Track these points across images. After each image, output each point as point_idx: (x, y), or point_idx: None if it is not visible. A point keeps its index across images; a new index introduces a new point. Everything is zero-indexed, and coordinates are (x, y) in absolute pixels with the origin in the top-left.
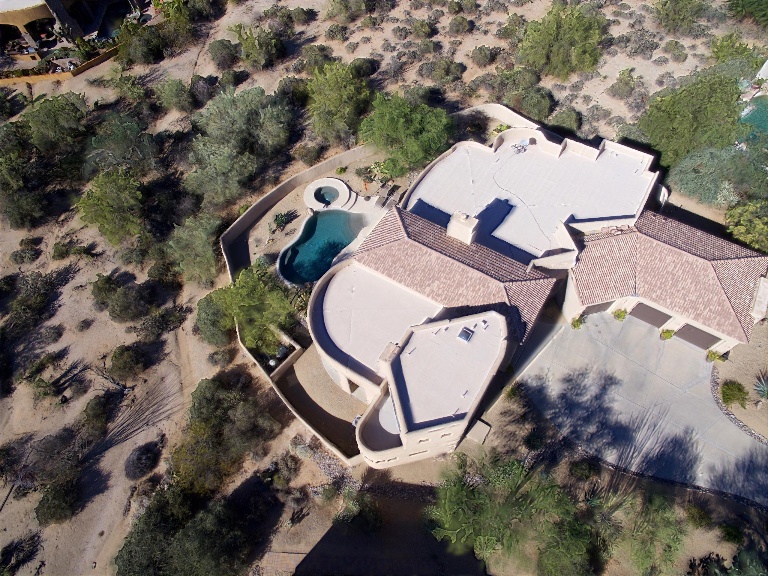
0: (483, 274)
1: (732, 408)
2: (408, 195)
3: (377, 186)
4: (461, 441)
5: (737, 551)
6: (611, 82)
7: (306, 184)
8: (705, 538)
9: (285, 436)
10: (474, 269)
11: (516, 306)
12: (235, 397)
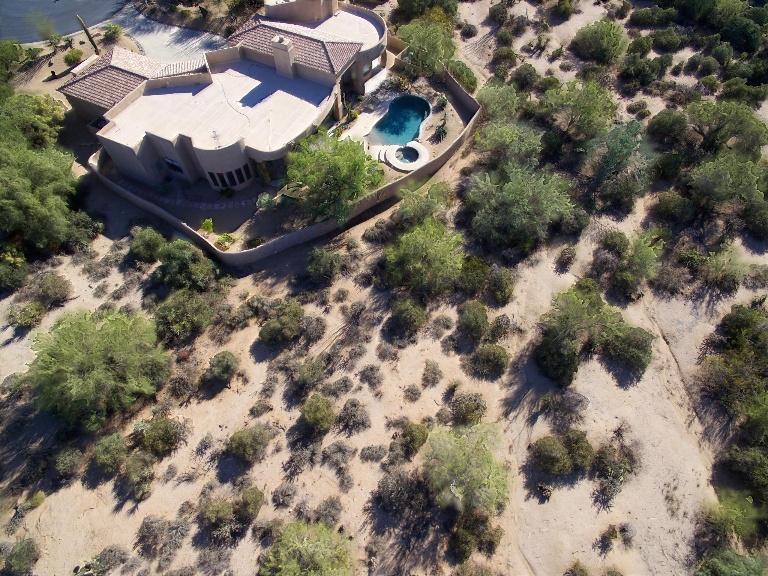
0: None
1: None
2: None
3: None
4: None
5: None
6: (52, 318)
7: None
8: None
9: None
10: None
11: None
12: None
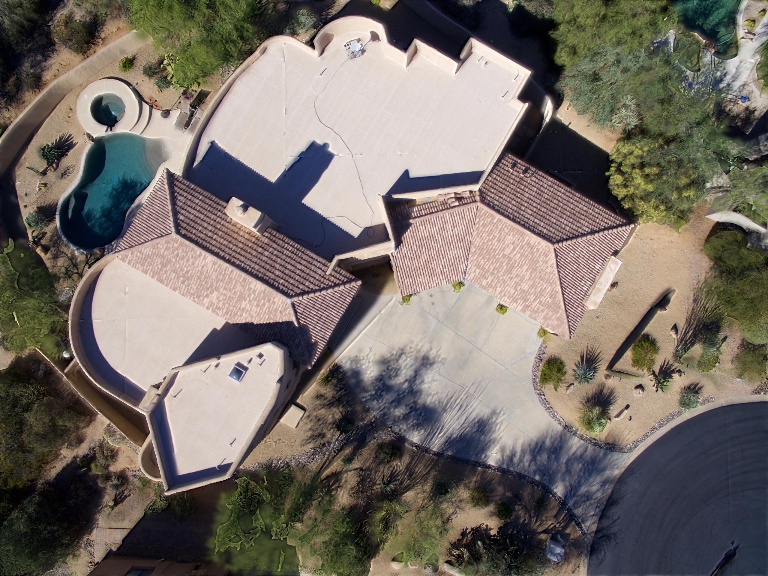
0: (267, 287)
1: (545, 389)
2: (196, 137)
3: (177, 92)
4: (275, 425)
5: (503, 523)
6: None
7: (79, 88)
8: (480, 513)
9: (99, 422)
10: (256, 280)
11: (306, 324)
12: (33, 392)
